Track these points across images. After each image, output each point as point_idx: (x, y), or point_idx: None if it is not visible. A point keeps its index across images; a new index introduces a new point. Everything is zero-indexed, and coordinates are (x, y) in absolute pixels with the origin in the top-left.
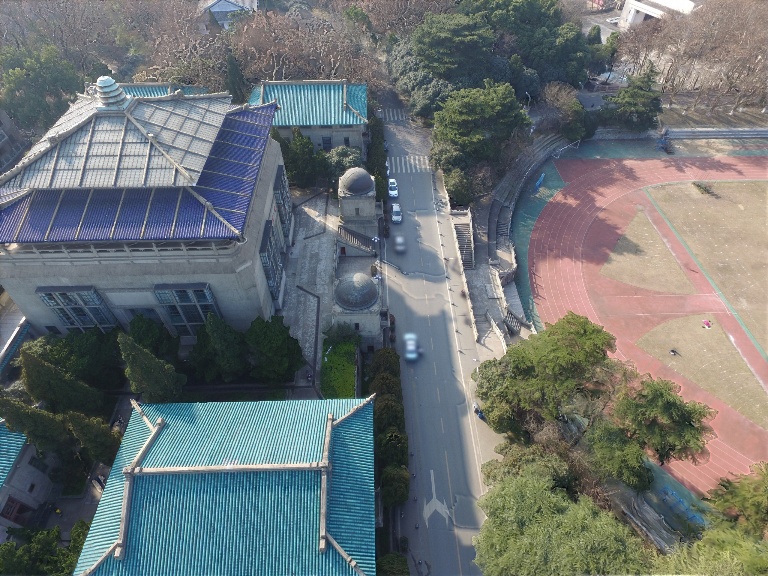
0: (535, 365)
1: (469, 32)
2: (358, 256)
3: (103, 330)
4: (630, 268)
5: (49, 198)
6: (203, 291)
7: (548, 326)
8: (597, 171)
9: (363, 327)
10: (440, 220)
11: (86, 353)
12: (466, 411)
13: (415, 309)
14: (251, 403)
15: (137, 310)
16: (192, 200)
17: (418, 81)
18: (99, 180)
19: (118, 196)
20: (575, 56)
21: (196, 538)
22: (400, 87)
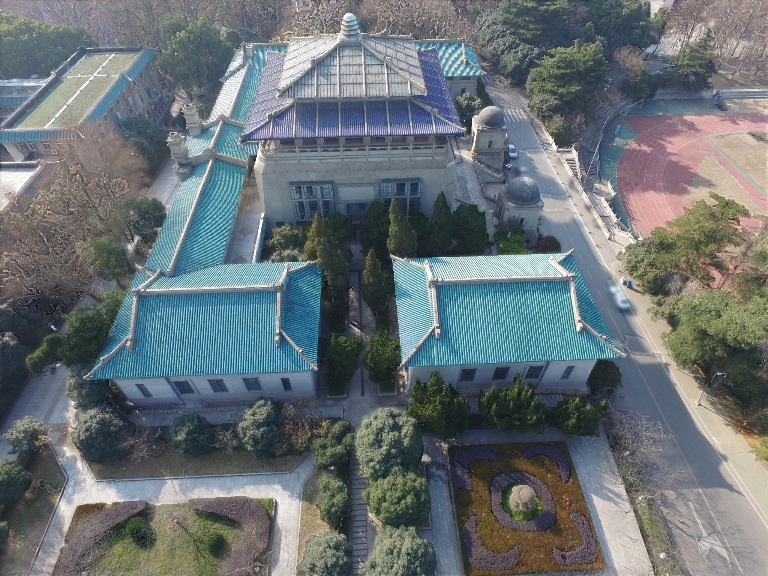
0: (683, 235)
1: (551, 2)
2: (489, 182)
3: (324, 224)
4: (707, 198)
5: (308, 108)
6: (417, 184)
7: (686, 209)
8: (662, 125)
9: (526, 222)
10: (549, 156)
11: (339, 228)
12: (615, 284)
13: (550, 218)
14: (481, 256)
15: (352, 207)
16: (419, 109)
17: (507, 46)
18: (353, 91)
19: (361, 106)
20: (639, 25)
21: (488, 324)
22: (489, 52)
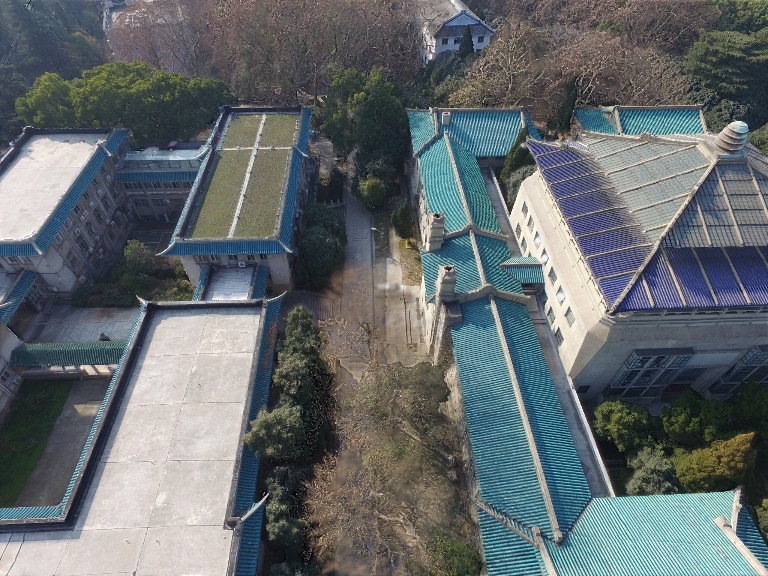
0: None
1: (758, 51)
2: None
3: (646, 390)
4: None
5: (683, 255)
6: None
7: None
8: None
9: None
10: None
11: (723, 425)
12: None
13: None
14: None
15: None
16: None
17: (706, 101)
18: (760, 237)
19: (754, 253)
20: None
21: None
22: None
